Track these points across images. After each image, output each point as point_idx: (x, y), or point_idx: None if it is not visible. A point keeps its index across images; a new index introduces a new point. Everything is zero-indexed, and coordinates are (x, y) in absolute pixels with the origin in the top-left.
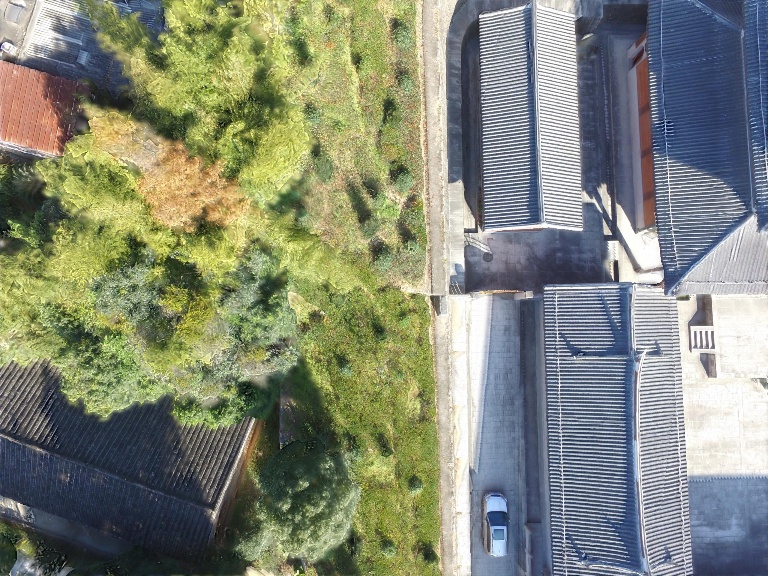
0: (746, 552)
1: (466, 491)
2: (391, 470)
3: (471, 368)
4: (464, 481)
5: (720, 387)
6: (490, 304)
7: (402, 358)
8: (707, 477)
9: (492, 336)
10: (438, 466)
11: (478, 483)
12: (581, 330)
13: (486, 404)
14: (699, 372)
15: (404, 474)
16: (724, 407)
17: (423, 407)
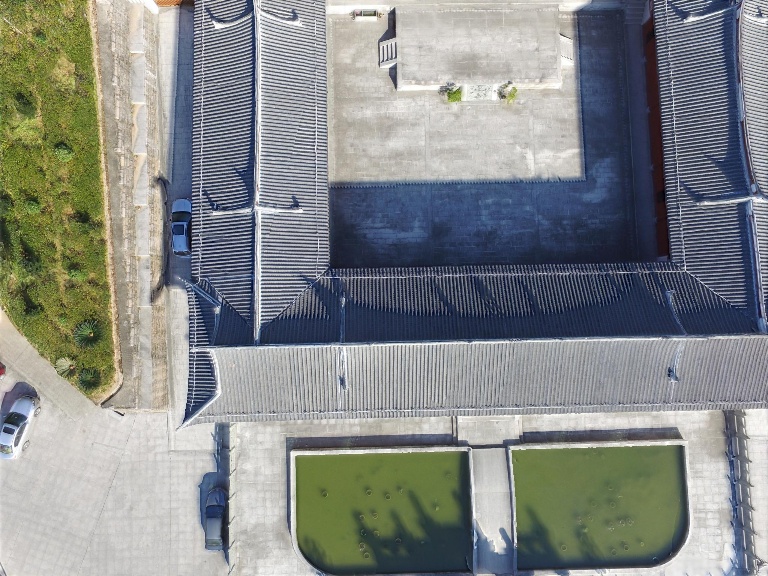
0: (427, 252)
1: (144, 185)
2: (39, 136)
3: (161, 80)
4: (142, 176)
5: (408, 100)
6: (177, 17)
7: (46, 26)
8: (392, 183)
9: (180, 48)
10: (104, 150)
11: (172, 193)
12: (222, 1)
13: (177, 115)
14: (388, 86)
15: (49, 137)
16: (411, 118)
17: (76, 81)
